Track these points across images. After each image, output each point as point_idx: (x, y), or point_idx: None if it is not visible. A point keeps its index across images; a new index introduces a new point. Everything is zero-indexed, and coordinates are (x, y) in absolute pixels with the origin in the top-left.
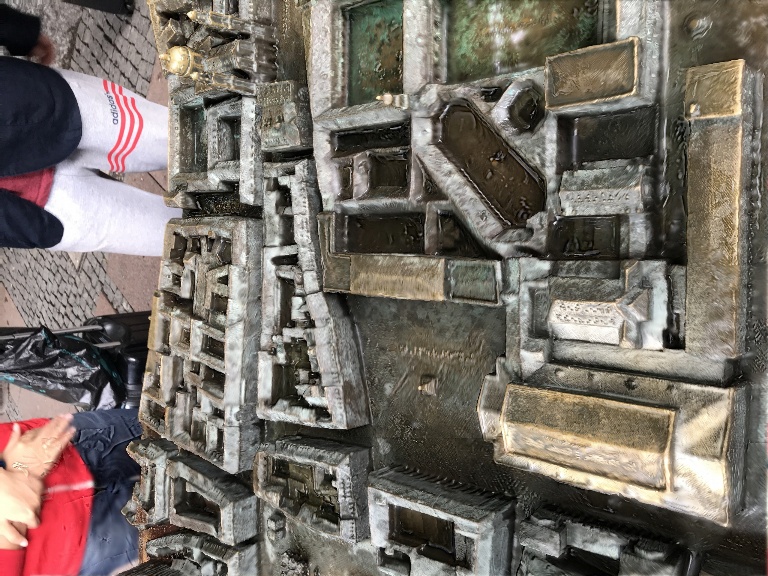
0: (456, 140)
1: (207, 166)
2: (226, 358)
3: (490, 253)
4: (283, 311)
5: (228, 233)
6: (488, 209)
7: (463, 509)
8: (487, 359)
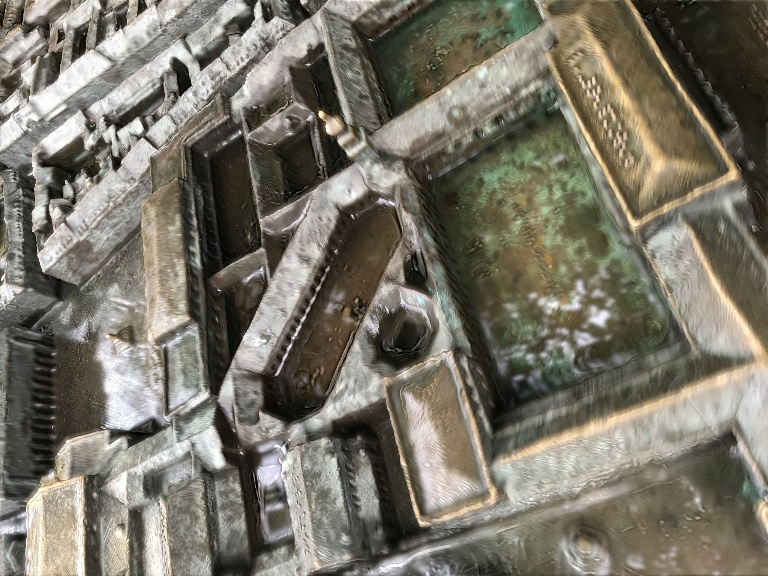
0: (370, 234)
1: None
2: (68, 71)
3: None
4: (138, 109)
5: None
6: (281, 337)
7: None
8: (160, 403)
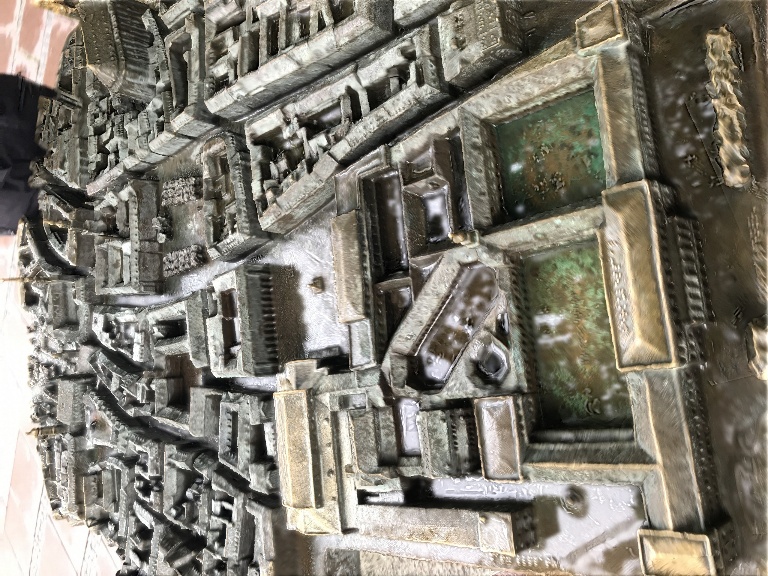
0: (480, 276)
1: None
2: (266, 66)
3: (386, 348)
4: (321, 113)
5: (357, 7)
6: (419, 336)
7: (248, 355)
8: (343, 337)
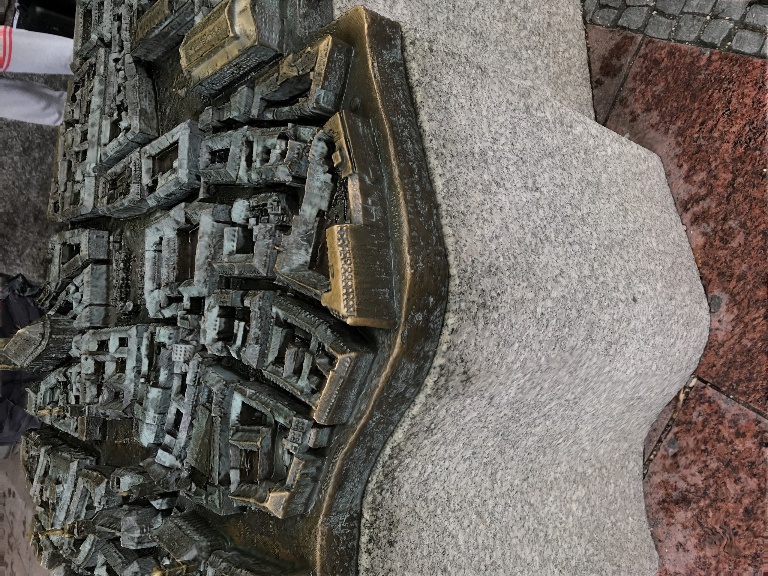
0: None
1: (91, 31)
2: (88, 132)
3: None
4: None
5: (95, 58)
6: None
7: None
8: None
